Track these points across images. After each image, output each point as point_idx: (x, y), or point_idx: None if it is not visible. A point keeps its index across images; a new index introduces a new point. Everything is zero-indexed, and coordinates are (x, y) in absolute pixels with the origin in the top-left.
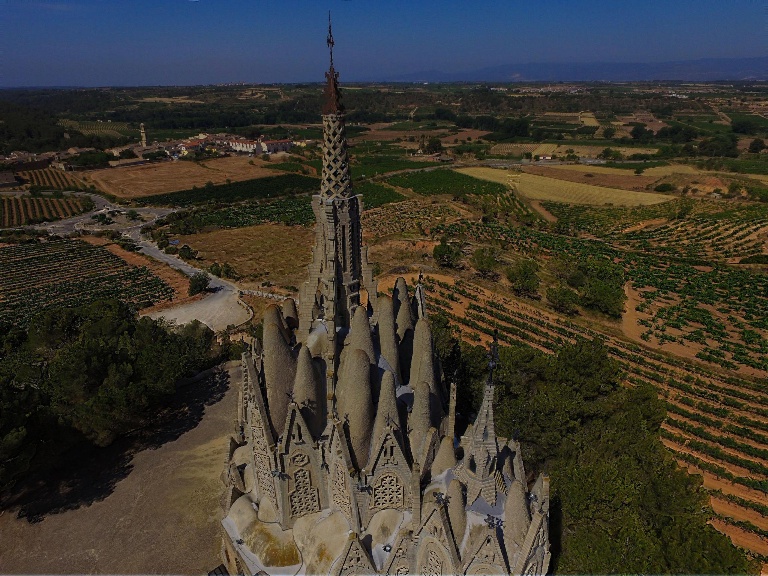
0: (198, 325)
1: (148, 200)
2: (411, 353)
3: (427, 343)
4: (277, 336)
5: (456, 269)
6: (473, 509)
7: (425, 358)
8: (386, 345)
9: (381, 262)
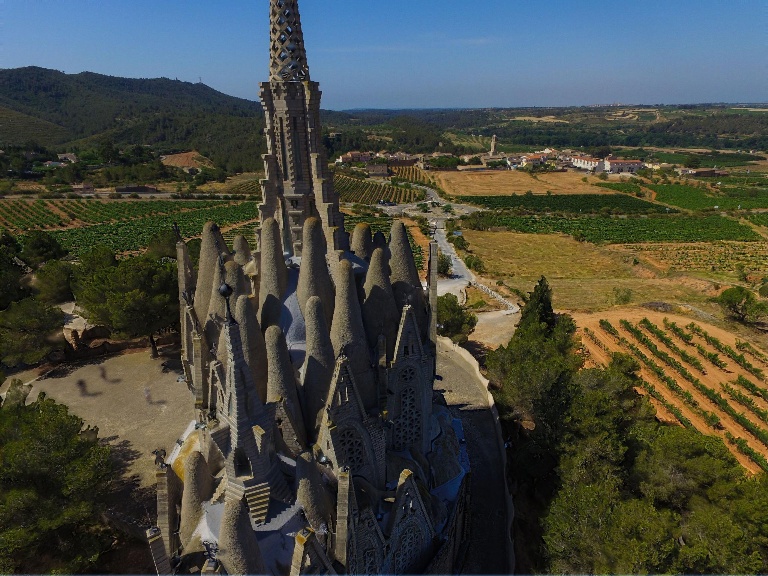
0: None
1: (468, 199)
2: (378, 321)
3: (341, 293)
4: (208, 235)
5: (754, 329)
6: (208, 510)
7: (307, 303)
8: (301, 281)
9: (654, 297)
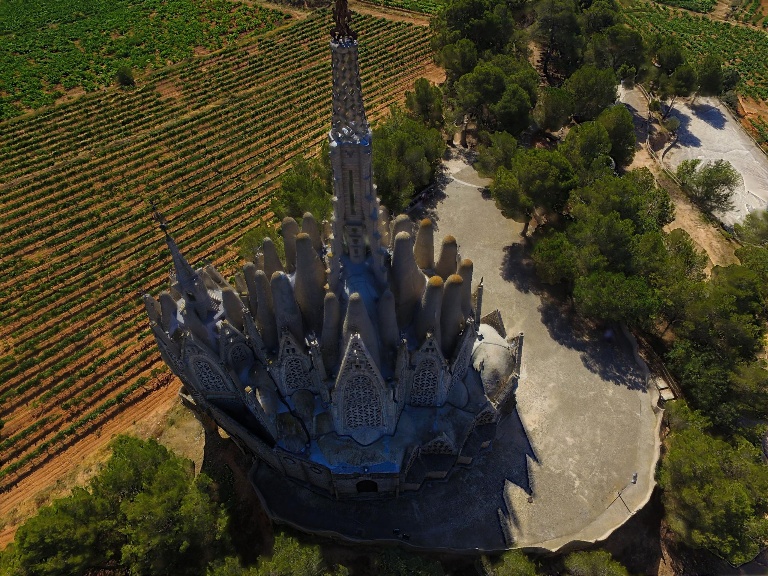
0: (761, 379)
1: None
2: None
3: None
4: None
5: None
6: None
7: None
8: None
9: None
